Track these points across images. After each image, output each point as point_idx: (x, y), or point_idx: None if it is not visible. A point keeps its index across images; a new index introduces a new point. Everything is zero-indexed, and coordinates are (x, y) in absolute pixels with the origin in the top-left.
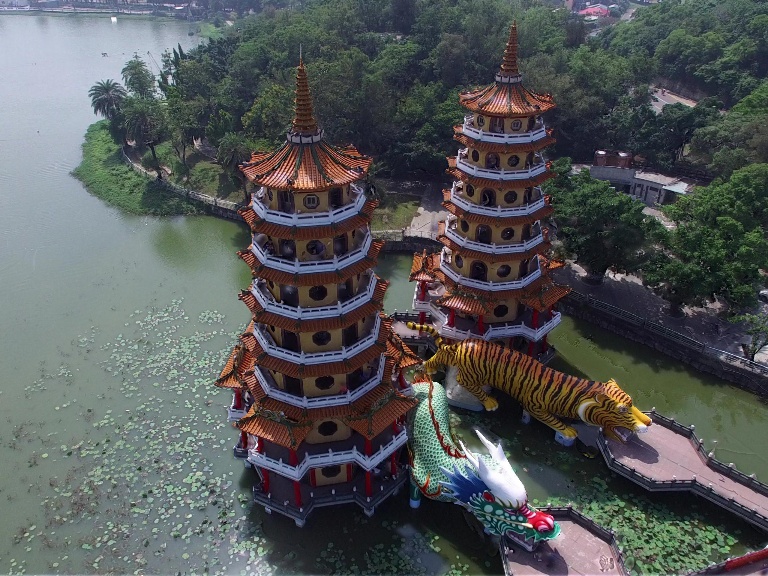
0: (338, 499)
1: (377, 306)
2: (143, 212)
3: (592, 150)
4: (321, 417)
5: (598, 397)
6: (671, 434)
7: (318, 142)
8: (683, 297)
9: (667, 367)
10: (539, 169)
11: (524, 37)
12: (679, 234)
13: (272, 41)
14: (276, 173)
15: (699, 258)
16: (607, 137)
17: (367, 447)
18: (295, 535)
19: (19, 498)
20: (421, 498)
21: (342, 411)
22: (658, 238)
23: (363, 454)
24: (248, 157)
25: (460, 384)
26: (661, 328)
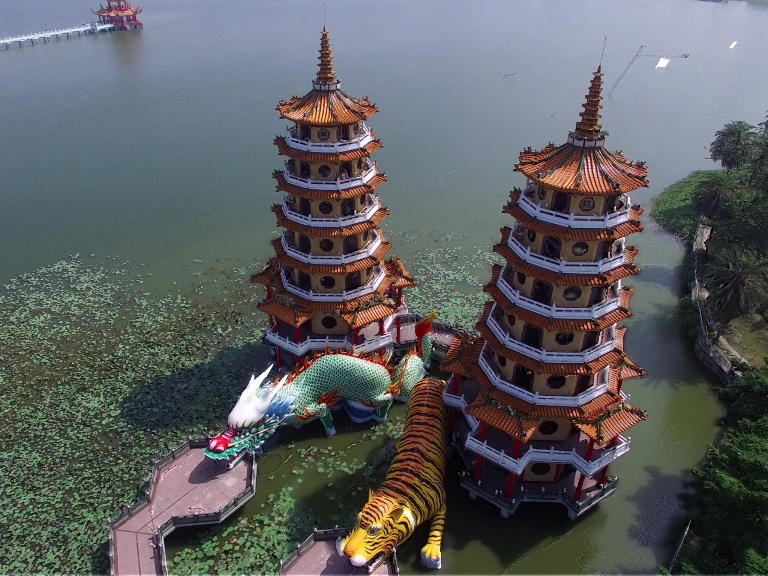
0: None
1: None
2: (655, 215)
3: None
4: None
5: None
6: None
7: (320, 91)
8: None
9: None
10: (549, 263)
11: None
12: None
13: None
14: None
15: None
16: None
17: None
18: None
19: None
20: None
21: None
22: None
23: (274, 328)
24: (721, 203)
25: None
26: None
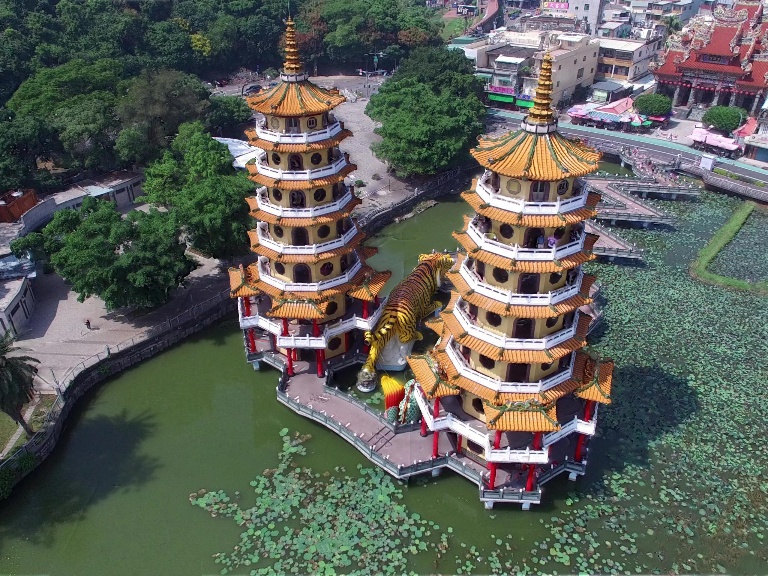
0: None
1: None
2: None
3: None
4: None
5: None
6: None
7: None
8: None
9: None
10: None
11: None
12: None
13: None
14: None
15: None
16: None
17: None
18: None
19: None
20: None
21: None
22: None
23: None
24: None
25: None
26: None
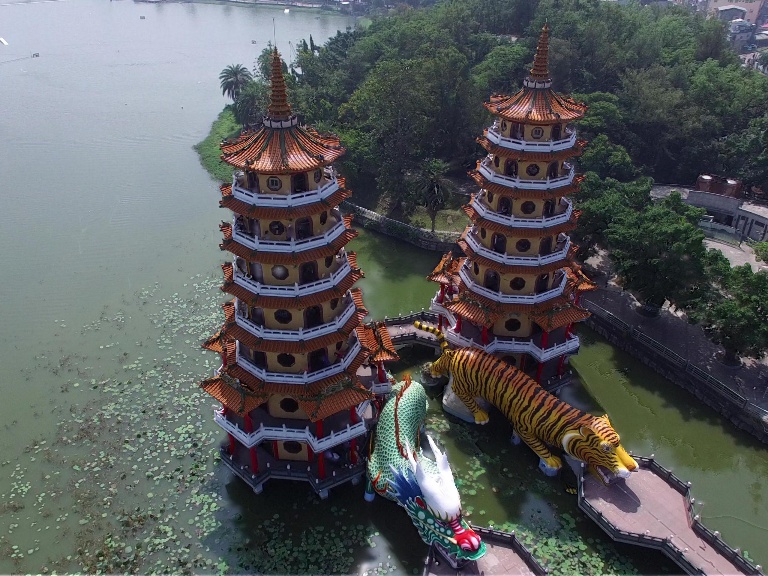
0: (293, 475)
1: (337, 294)
2: None
3: (698, 174)
4: (276, 392)
5: (583, 430)
6: (665, 487)
7: (289, 128)
8: (737, 344)
9: (700, 417)
10: (562, 181)
11: (646, 46)
12: (739, 273)
13: (388, 37)
14: (244, 153)
15: (756, 302)
16: (719, 161)
17: (318, 430)
18: (253, 500)
19: (43, 416)
20: (376, 493)
21: (296, 390)
22: (715, 274)
23: (314, 435)
24: None
25: (453, 391)
26: (703, 374)
